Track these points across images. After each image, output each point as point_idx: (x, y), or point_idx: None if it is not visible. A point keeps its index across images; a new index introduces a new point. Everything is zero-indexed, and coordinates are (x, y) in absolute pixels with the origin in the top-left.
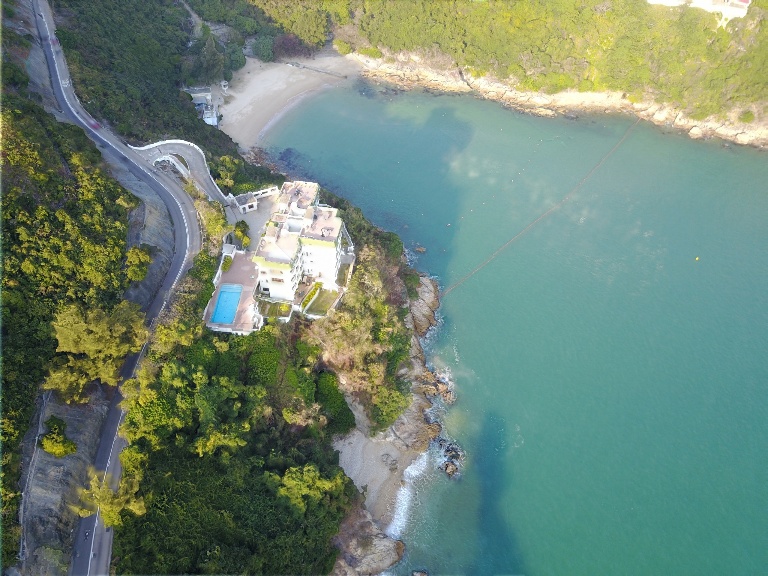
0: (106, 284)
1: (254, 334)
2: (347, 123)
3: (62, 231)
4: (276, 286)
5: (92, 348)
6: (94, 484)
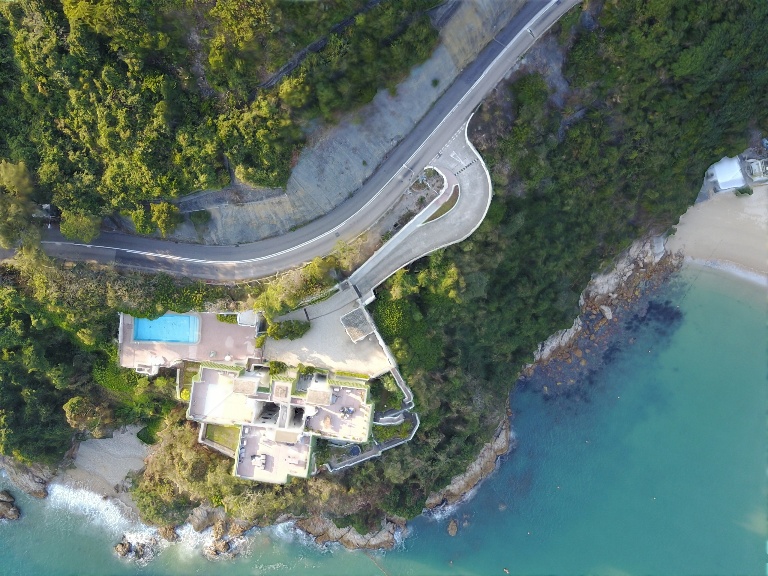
0: (105, 192)
1: None
2: (764, 407)
3: (148, 116)
4: None
5: None
6: None
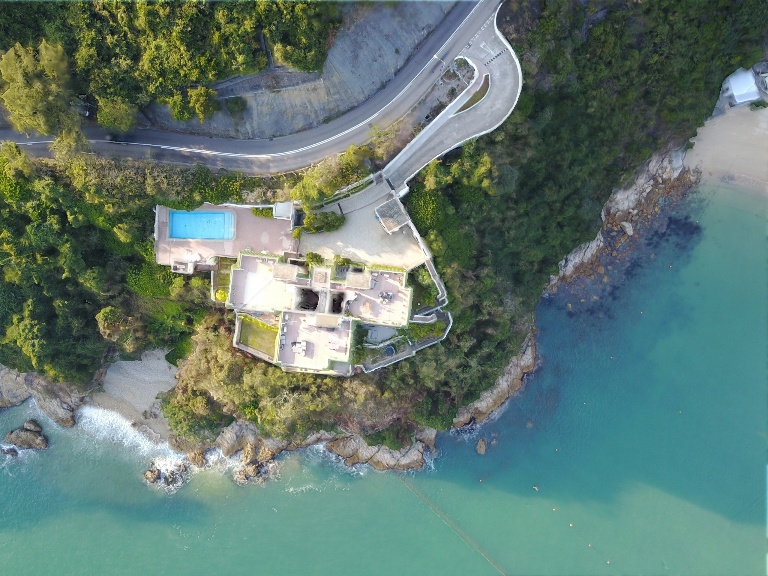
0: (143, 77)
1: (167, 266)
2: None
3: None
4: None
5: (6, 100)
6: None
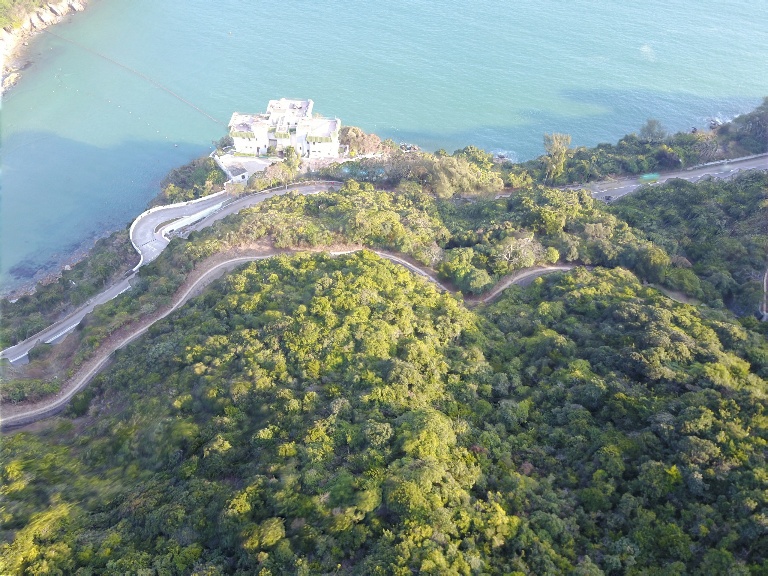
0: None
1: None
2: None
3: None
4: None
5: None
6: (558, 146)
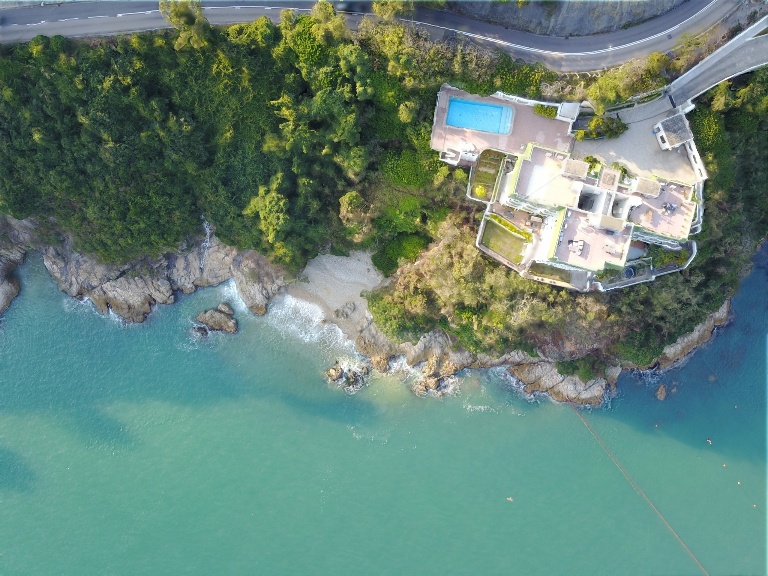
0: None
1: (435, 153)
2: None
3: None
4: (508, 179)
5: None
6: None
